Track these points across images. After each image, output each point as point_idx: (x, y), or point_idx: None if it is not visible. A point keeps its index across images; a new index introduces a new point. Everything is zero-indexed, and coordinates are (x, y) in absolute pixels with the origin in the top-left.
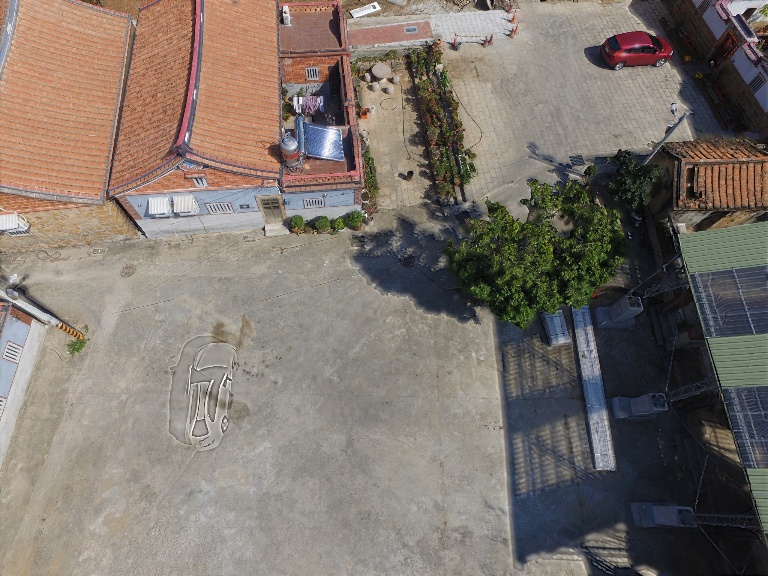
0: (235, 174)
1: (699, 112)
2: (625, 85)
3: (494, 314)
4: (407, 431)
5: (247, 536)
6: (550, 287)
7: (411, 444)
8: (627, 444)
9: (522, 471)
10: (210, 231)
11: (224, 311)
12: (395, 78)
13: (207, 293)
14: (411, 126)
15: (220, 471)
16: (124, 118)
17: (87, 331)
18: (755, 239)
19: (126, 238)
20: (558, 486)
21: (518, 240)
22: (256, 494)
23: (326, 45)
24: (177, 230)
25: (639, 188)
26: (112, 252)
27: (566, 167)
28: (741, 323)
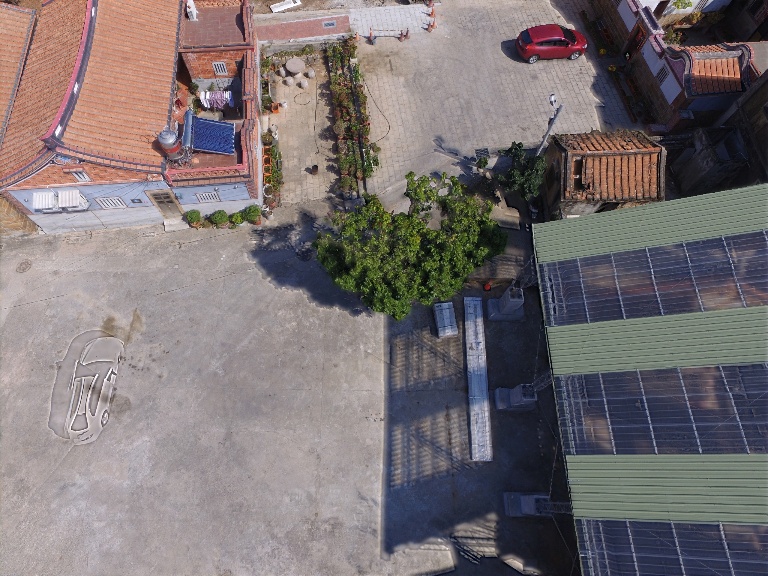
0: (115, 168)
1: (610, 105)
2: (538, 78)
3: None
4: (287, 424)
5: (116, 529)
6: (412, 278)
7: (290, 436)
8: (506, 435)
9: (398, 462)
10: (109, 226)
11: (116, 306)
12: (310, 73)
13: (101, 288)
14: (323, 120)
15: (96, 465)
16: (13, 113)
17: None
18: (600, 228)
19: (24, 234)
20: (433, 477)
21: (389, 232)
22: (129, 487)
23: (230, 39)
24: (74, 225)
25: (528, 180)
26: (9, 248)
27: (470, 160)
28: (578, 311)
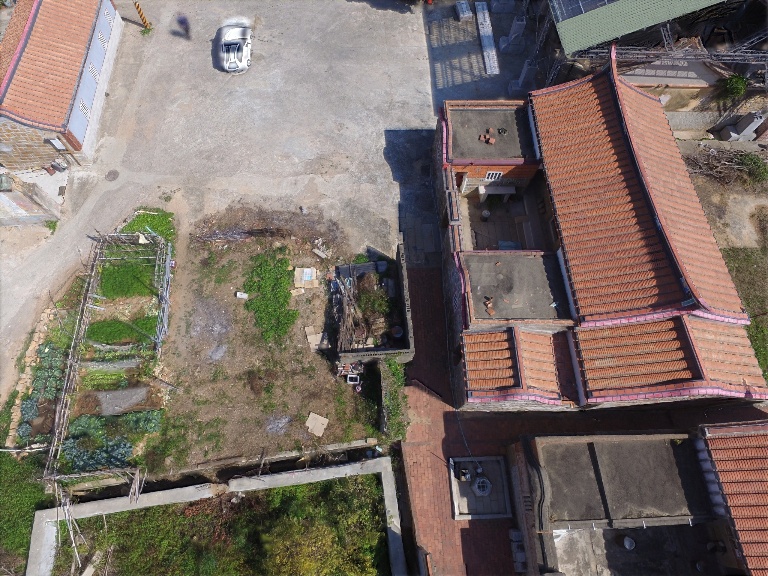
0: None
1: None
2: None
3: (423, 9)
4: (367, 62)
5: (268, 109)
6: None
7: (370, 67)
8: (508, 64)
9: (440, 77)
10: None
11: (242, 13)
12: None
13: (229, 6)
14: None
15: (248, 83)
16: None
17: (151, 25)
18: None
19: None
20: (463, 82)
21: None
22: (272, 91)
23: None
24: None
25: None
26: None
27: None
28: None
